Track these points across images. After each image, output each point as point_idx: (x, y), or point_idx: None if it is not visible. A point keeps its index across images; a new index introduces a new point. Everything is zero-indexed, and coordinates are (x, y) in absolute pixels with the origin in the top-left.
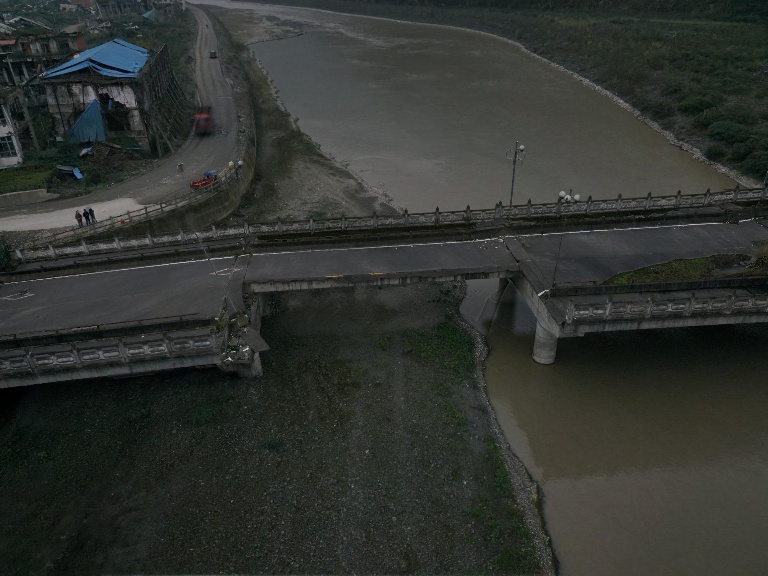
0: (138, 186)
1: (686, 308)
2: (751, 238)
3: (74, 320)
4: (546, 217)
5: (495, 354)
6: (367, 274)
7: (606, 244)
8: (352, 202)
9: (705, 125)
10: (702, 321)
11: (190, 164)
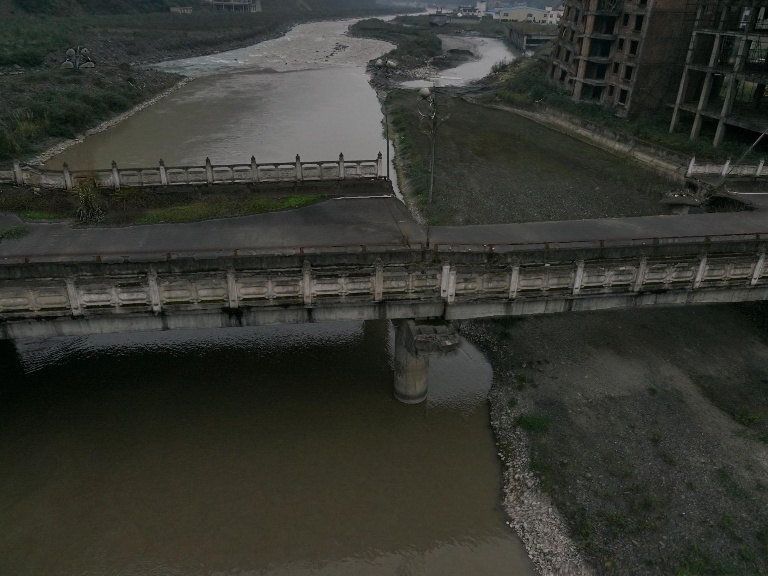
0: None
1: (259, 178)
2: (5, 247)
3: None
4: None
5: None
6: None
7: (267, 241)
8: None
9: None
10: None
11: None
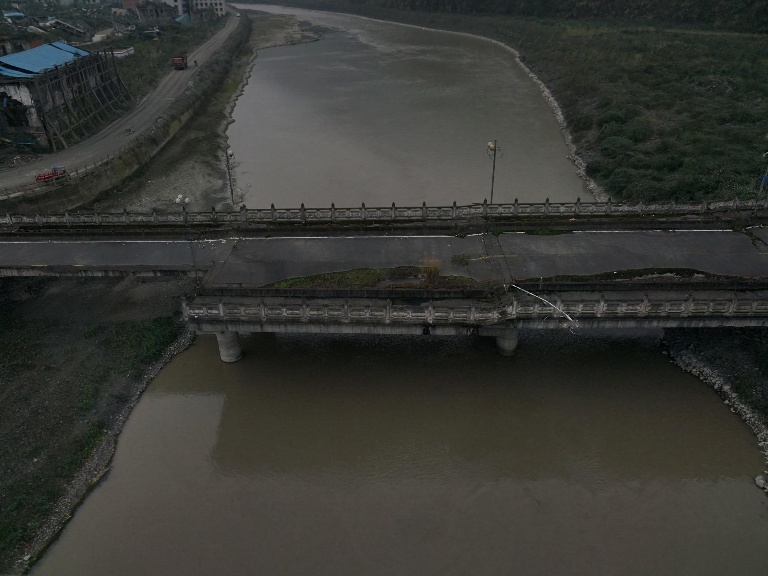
0: (3, 177)
1: (301, 314)
2: (458, 252)
3: None
4: (291, 222)
5: (194, 349)
6: (69, 265)
7: (312, 250)
8: (200, 201)
9: (602, 140)
10: (326, 328)
11: (68, 159)
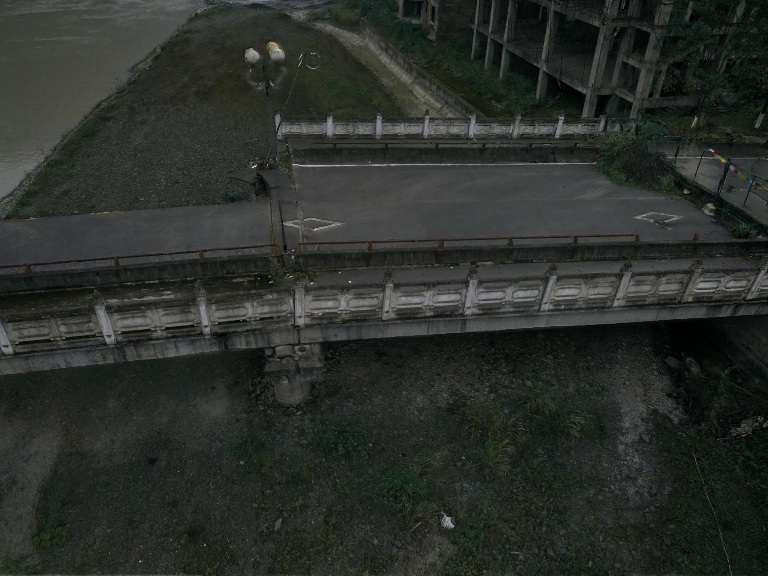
0: None
1: None
2: None
3: (502, 179)
4: None
5: None
6: None
7: None
8: None
9: None
10: None
11: None
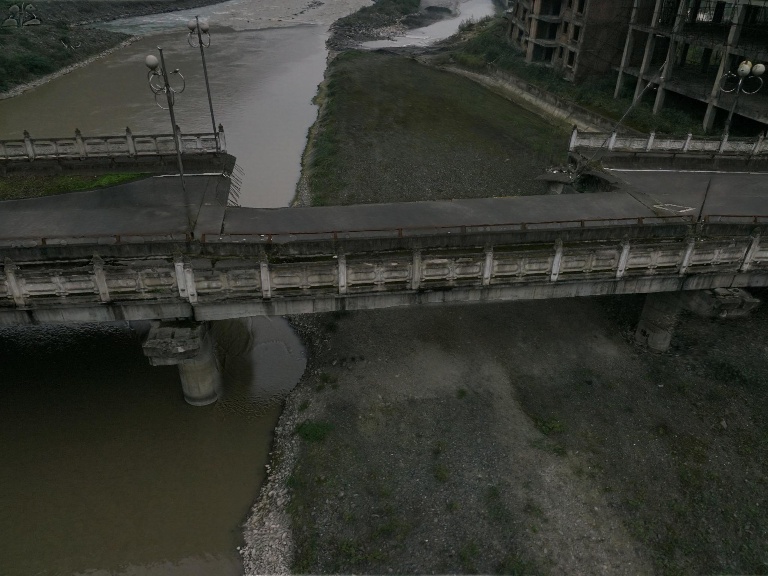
0: None
1: (87, 152)
2: None
3: None
4: None
5: None
6: None
7: (37, 227)
8: None
9: None
10: None
11: None
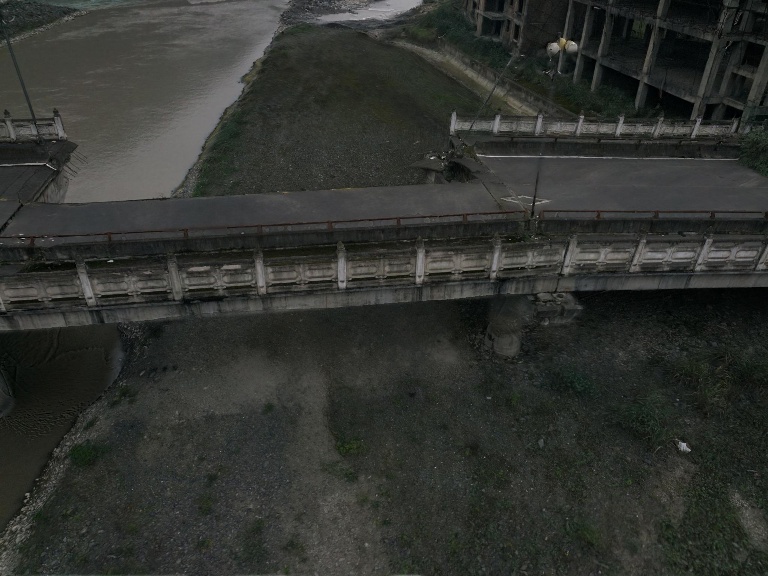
0: None
1: None
2: None
3: (663, 170)
4: None
5: None
6: None
7: None
8: None
9: None
10: None
11: None
